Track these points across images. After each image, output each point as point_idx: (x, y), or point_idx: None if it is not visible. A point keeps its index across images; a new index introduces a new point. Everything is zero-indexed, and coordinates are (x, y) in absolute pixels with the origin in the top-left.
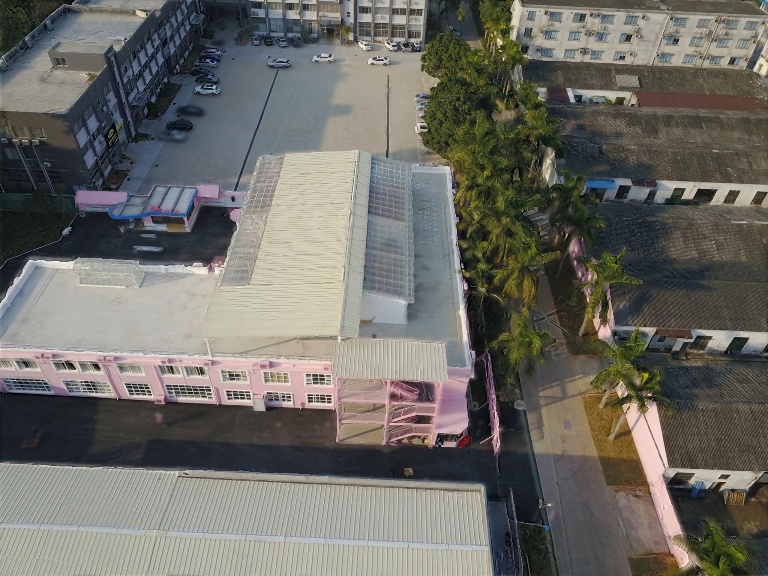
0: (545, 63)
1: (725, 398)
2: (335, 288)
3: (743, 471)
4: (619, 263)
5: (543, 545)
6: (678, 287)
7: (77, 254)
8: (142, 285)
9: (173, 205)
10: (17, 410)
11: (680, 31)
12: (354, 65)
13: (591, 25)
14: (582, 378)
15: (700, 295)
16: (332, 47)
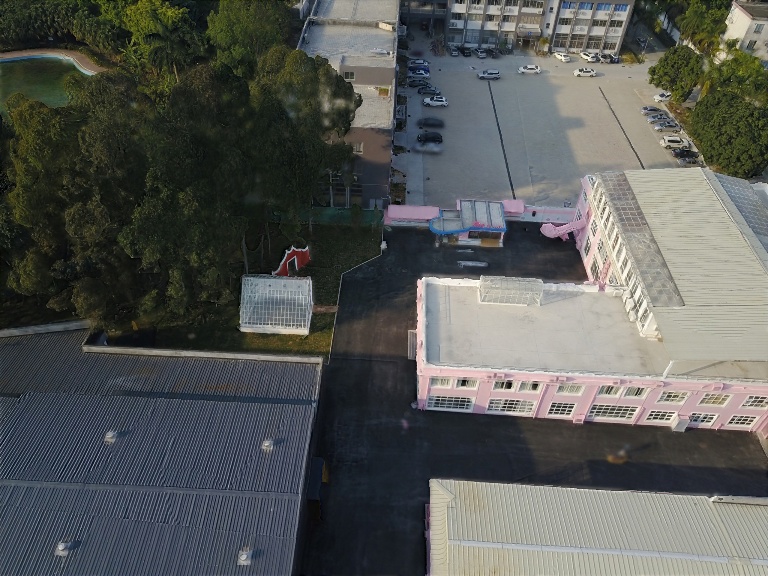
0: None
1: None
2: None
3: None
4: None
5: None
6: None
7: (406, 269)
8: (541, 303)
9: (488, 220)
10: (444, 428)
11: None
12: (561, 77)
13: None
14: None
15: None
16: (529, 58)
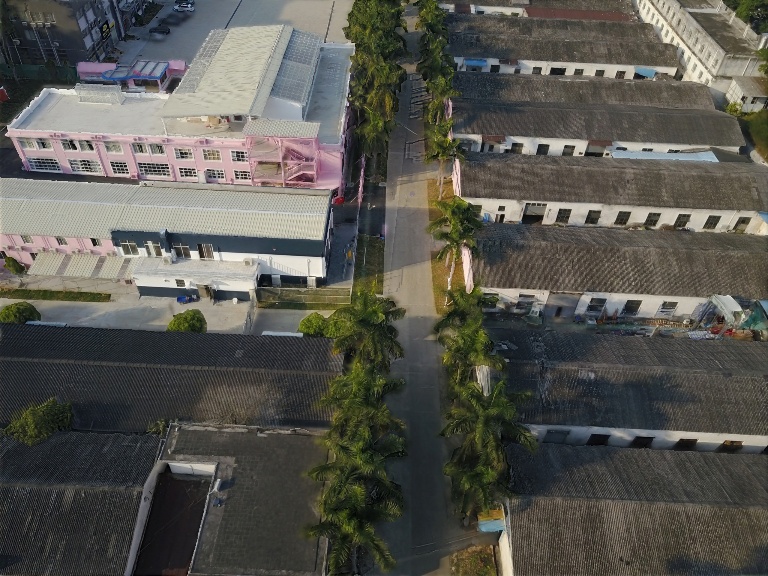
0: None
1: (507, 162)
2: (251, 92)
3: (510, 200)
4: (449, 83)
5: (377, 244)
6: (501, 111)
7: None
8: (123, 103)
9: (150, 72)
10: None
11: None
12: None
13: None
14: (431, 172)
15: (516, 116)
16: None
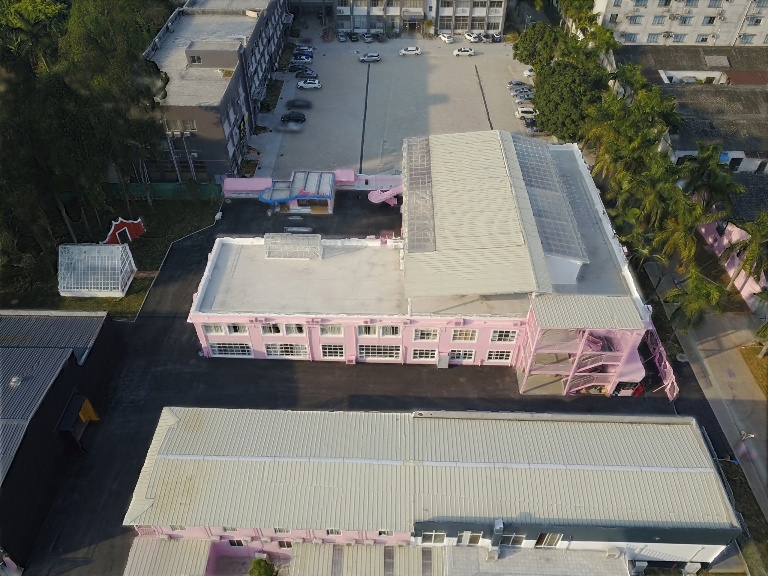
0: (634, 47)
1: None
2: (519, 251)
3: None
4: None
5: (737, 477)
6: None
7: (234, 236)
8: (324, 257)
9: (316, 188)
10: (224, 372)
11: (763, 12)
12: (440, 57)
13: (675, 9)
14: (735, 333)
15: None
16: (415, 41)
